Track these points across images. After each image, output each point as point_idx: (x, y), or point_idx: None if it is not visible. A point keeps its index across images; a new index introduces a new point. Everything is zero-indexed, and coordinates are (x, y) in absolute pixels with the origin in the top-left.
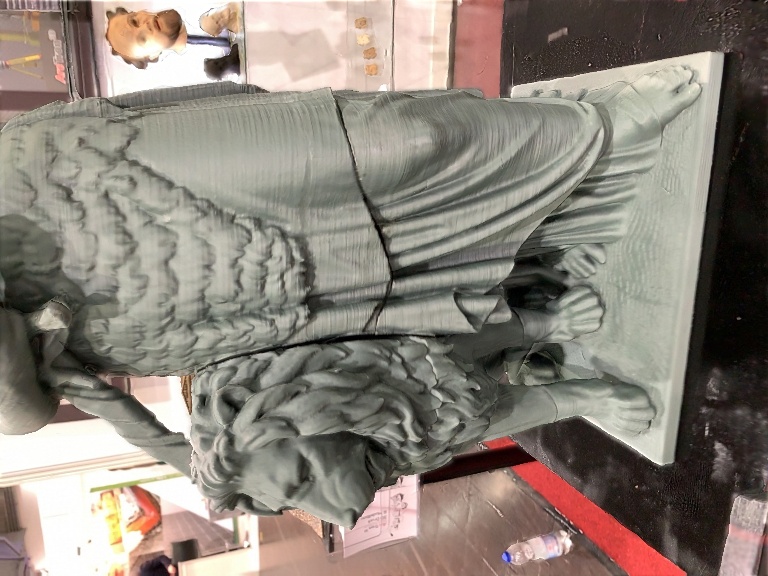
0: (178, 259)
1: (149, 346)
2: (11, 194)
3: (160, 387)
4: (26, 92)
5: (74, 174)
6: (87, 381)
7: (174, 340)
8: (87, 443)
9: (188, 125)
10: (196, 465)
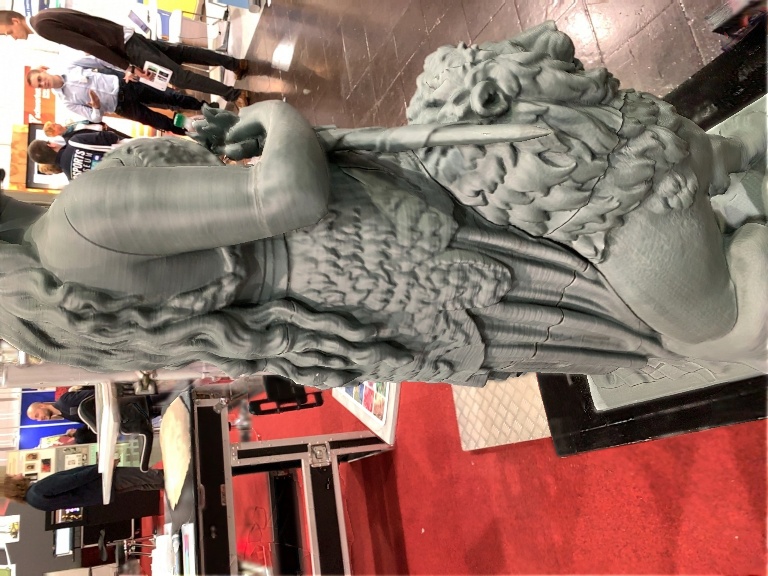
0: None
1: None
2: None
3: None
4: None
5: None
6: None
7: None
8: None
9: None
10: (428, 71)
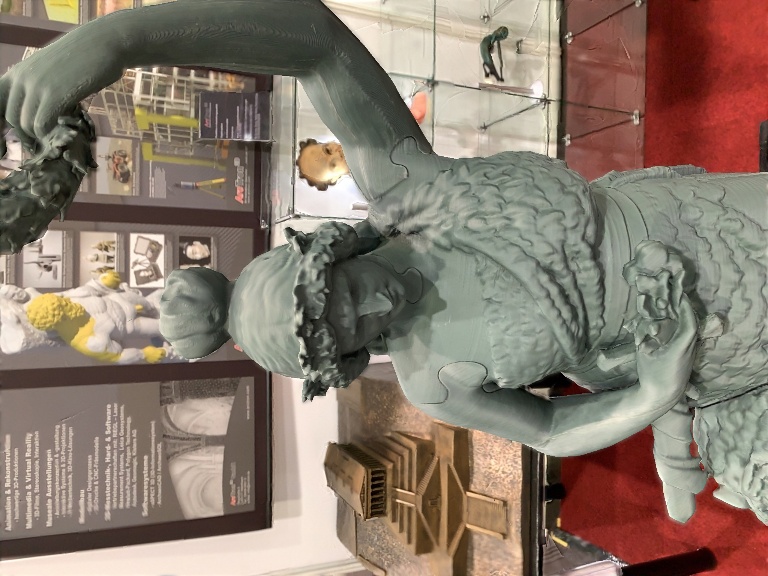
0: (767, 287)
1: (734, 363)
2: (663, 229)
3: (292, 501)
4: (209, 210)
5: (699, 216)
6: (696, 392)
7: (754, 358)
8: (218, 563)
9: (759, 184)
10: None
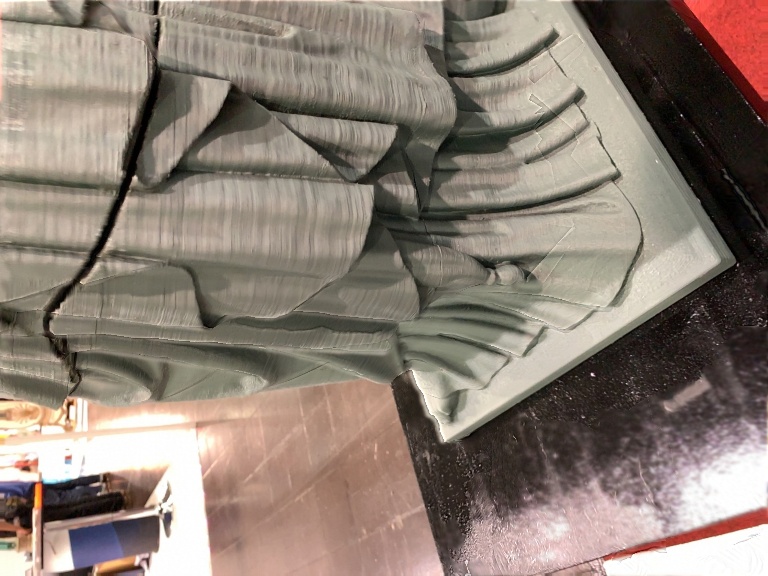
0: None
1: None
2: None
3: None
4: None
5: None
6: None
7: None
8: None
9: None
10: None
